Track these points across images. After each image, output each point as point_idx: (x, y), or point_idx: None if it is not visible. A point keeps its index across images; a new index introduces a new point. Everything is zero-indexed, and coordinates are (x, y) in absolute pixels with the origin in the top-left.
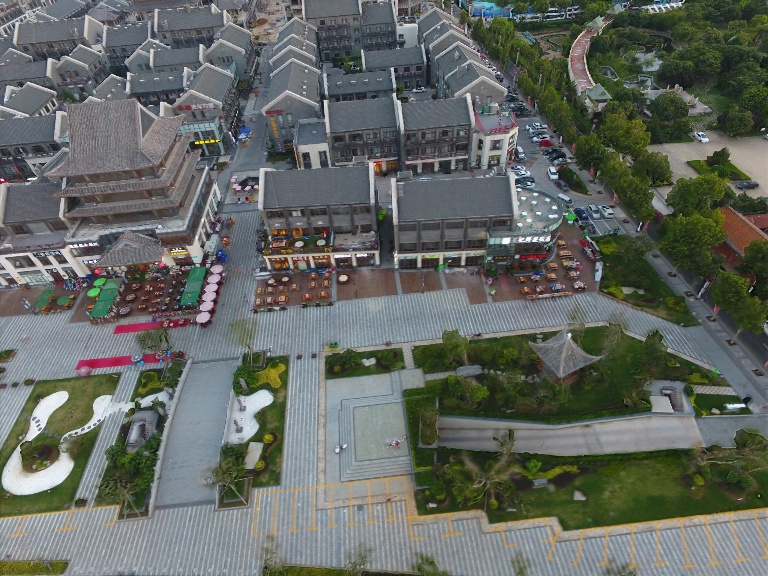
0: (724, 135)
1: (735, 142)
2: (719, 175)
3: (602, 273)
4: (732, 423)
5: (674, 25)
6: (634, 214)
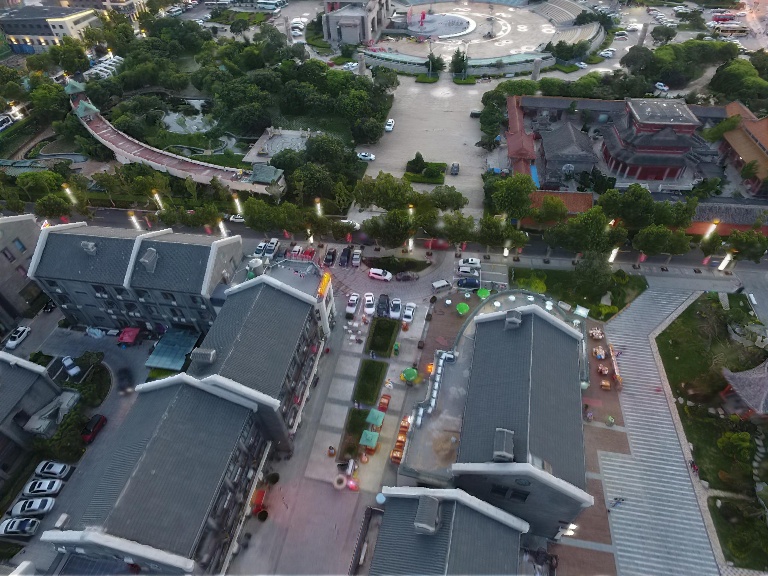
0: (368, 145)
1: (383, 146)
2: (438, 175)
3: (584, 308)
4: (760, 310)
5: (153, 78)
6: (513, 246)
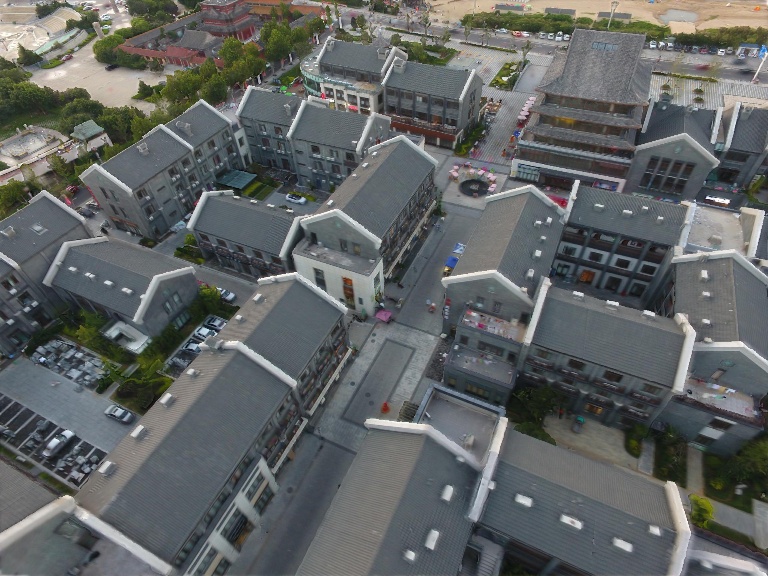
0: None
1: None
2: None
3: None
4: None
5: None
6: None
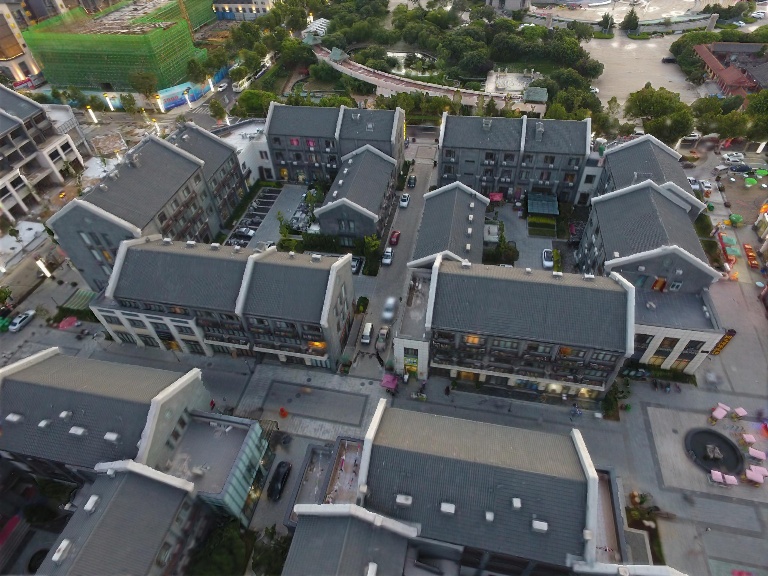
0: None
1: (599, 83)
2: None
3: None
4: None
5: (367, 34)
6: None
